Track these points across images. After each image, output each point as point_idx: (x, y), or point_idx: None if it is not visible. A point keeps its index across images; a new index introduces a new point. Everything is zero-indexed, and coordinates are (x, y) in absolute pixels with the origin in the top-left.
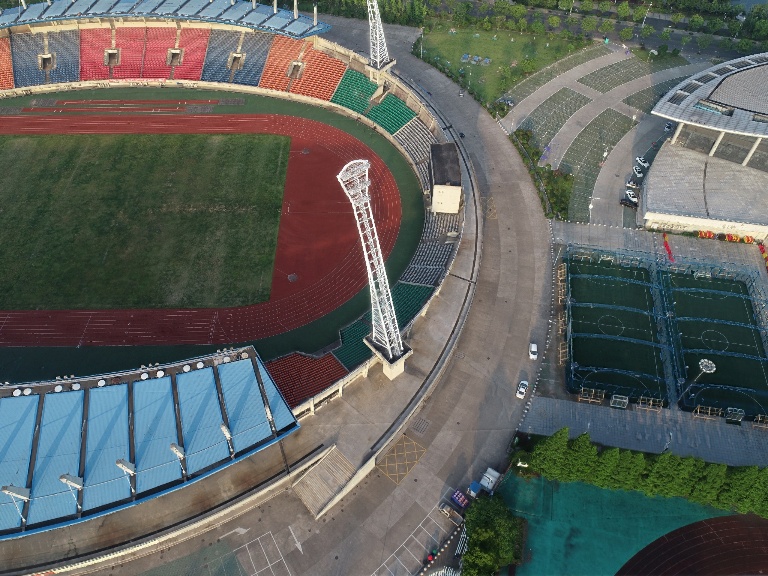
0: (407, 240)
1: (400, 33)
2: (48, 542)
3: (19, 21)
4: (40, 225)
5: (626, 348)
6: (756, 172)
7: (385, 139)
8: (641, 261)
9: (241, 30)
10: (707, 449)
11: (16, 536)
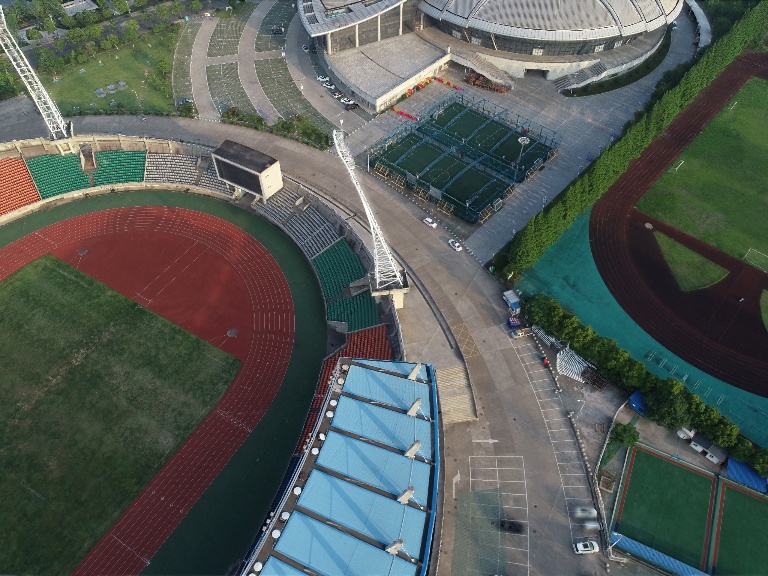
0: (267, 236)
1: (6, 110)
2: None
3: None
4: None
5: (461, 179)
6: (389, 40)
7: (135, 191)
8: (406, 130)
9: None
10: (551, 189)
11: None
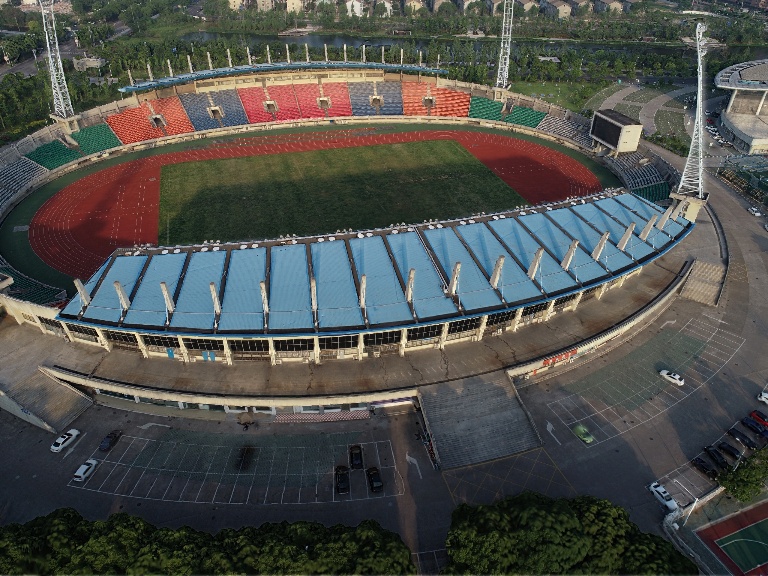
0: (604, 176)
1: None
2: (552, 337)
3: (204, 74)
4: (306, 200)
5: None
6: None
7: (526, 135)
8: None
9: (372, 81)
10: None
11: (581, 290)
